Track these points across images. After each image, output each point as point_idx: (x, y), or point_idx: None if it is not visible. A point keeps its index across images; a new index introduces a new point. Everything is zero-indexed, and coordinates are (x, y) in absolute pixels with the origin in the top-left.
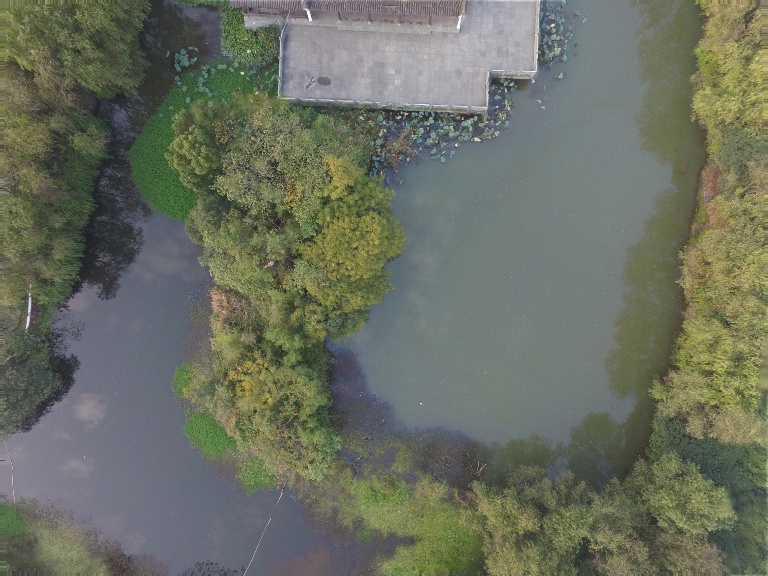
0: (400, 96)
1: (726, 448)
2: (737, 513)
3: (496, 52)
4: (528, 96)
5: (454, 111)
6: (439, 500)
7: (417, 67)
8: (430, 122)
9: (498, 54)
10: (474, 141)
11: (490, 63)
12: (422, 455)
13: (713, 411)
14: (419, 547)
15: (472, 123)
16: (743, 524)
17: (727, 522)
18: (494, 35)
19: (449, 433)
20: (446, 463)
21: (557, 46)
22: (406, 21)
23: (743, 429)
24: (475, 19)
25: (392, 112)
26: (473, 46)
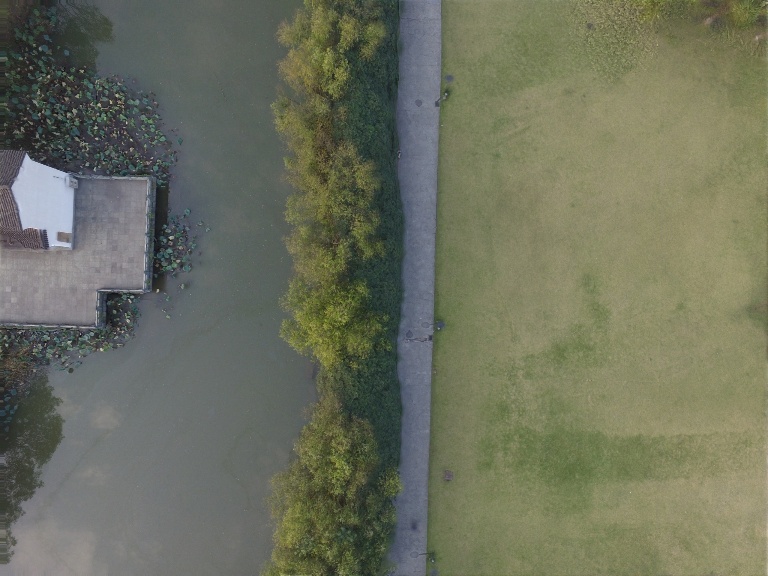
0: (16, 314)
1: None
2: None
3: (110, 268)
4: (153, 306)
5: None
6: None
7: (33, 284)
8: (46, 339)
9: (112, 270)
10: (100, 351)
11: (104, 279)
12: None
13: None
14: None
15: (89, 338)
16: None
17: None
18: (108, 251)
19: None
20: None
21: (175, 259)
22: (17, 241)
23: None
24: (89, 235)
25: (9, 330)
26: (87, 263)
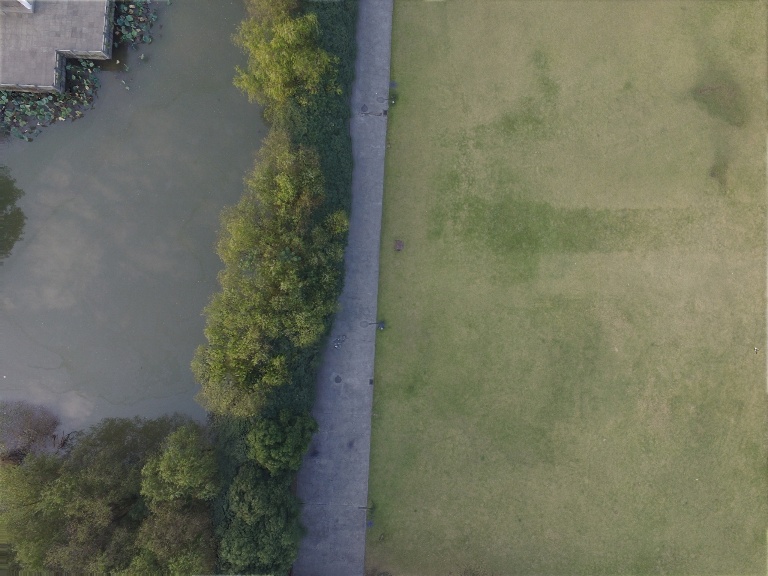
0: None
1: (215, 420)
2: (212, 483)
3: (70, 32)
4: (113, 77)
5: (29, 90)
6: (23, 472)
7: None
8: (4, 101)
9: (72, 34)
10: (59, 121)
11: (64, 43)
12: (5, 428)
13: (205, 384)
14: (3, 517)
15: (47, 102)
16: (217, 494)
17: (196, 491)
18: (69, 16)
19: (32, 407)
20: (30, 436)
21: (135, 27)
22: None
23: (227, 402)
24: None
25: None
26: (48, 26)
